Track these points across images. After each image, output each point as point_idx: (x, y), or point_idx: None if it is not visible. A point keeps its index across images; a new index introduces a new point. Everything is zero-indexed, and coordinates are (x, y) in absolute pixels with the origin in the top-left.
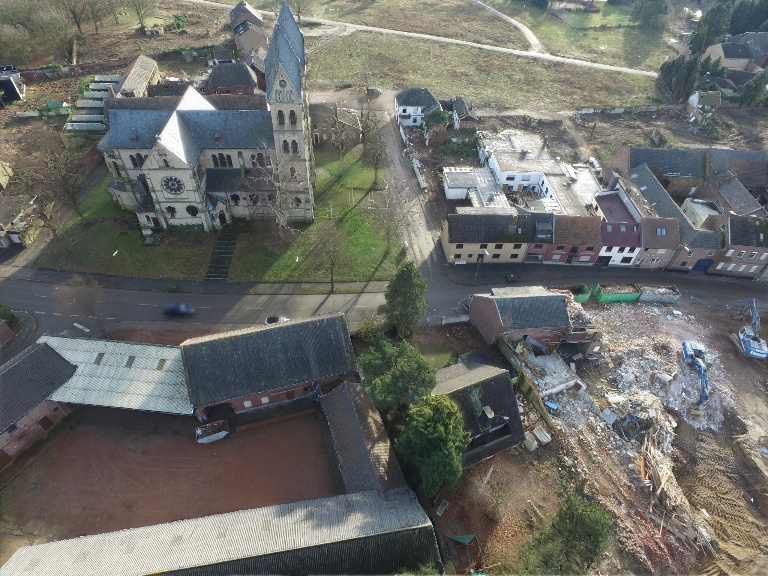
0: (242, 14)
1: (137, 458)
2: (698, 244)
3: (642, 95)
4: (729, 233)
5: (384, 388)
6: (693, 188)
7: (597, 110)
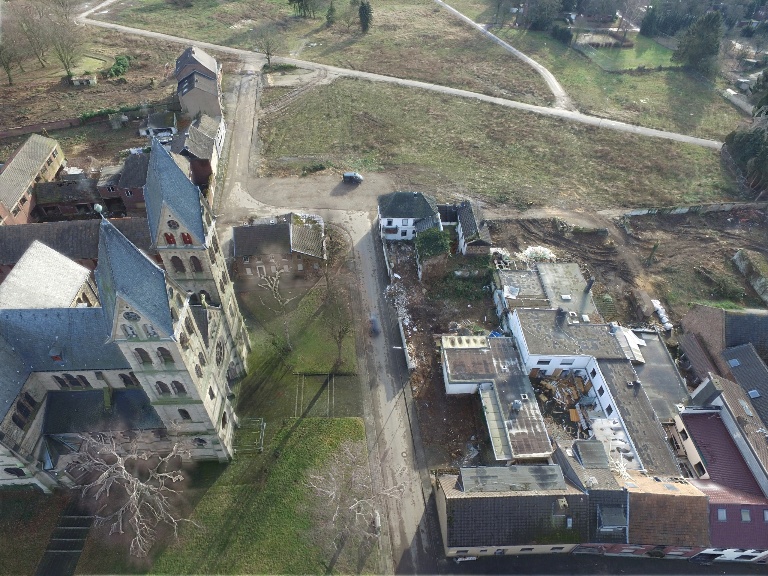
0: (188, 65)
1: None
2: None
3: (706, 180)
4: None
5: None
6: None
7: (652, 211)
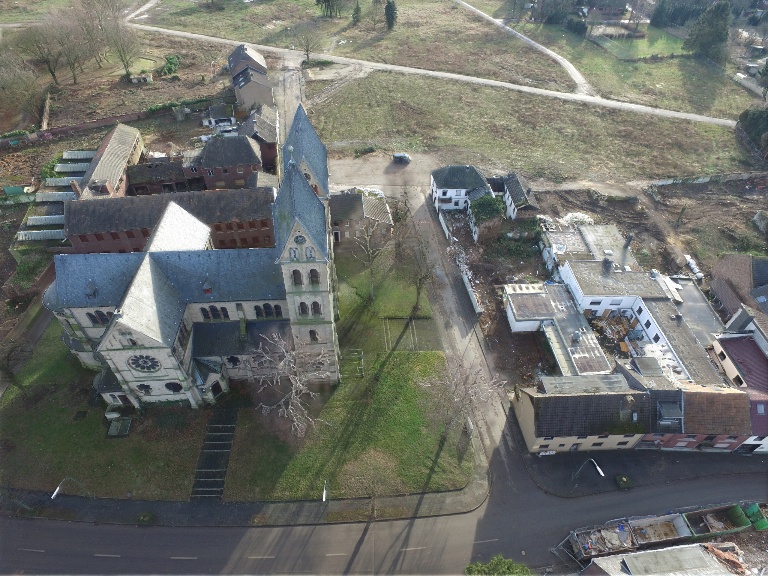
0: (242, 61)
1: None
2: None
3: (723, 154)
4: None
5: None
6: None
7: (677, 180)
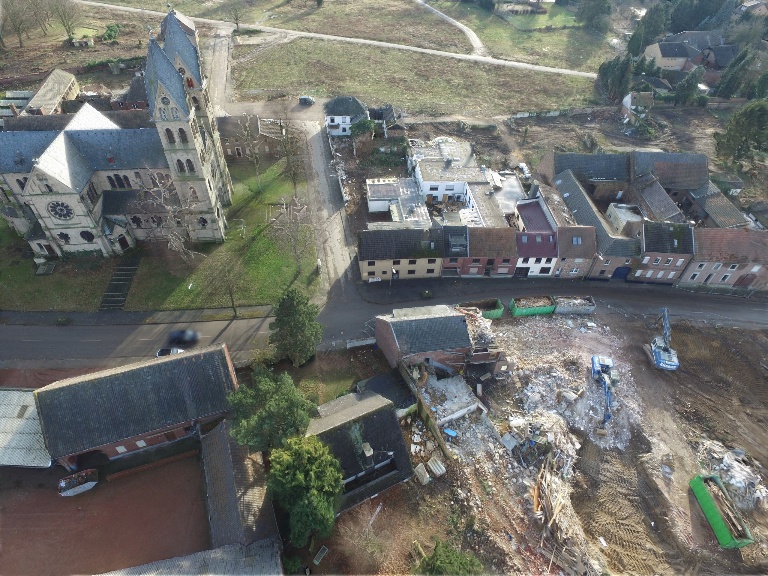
0: None
1: None
2: (614, 252)
3: (580, 97)
4: (644, 240)
5: (248, 431)
6: (620, 192)
7: (532, 114)
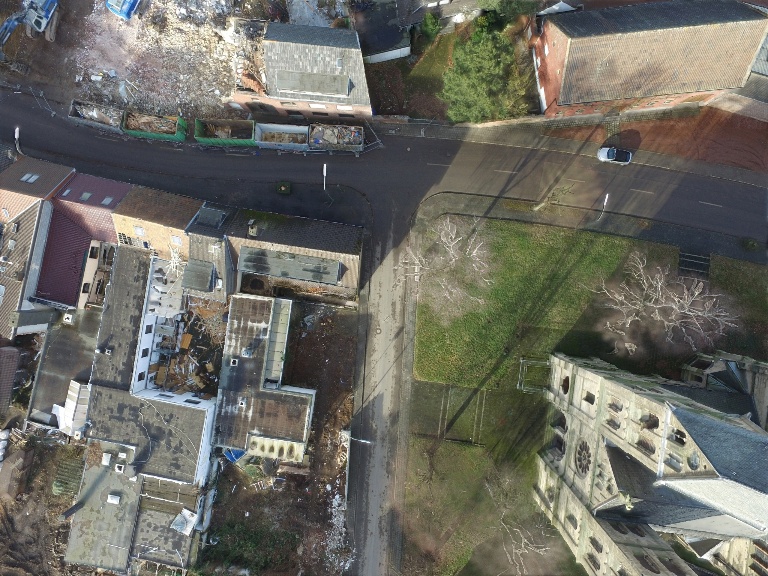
0: None
1: (760, 2)
2: None
3: None
4: None
5: None
6: None
7: None
